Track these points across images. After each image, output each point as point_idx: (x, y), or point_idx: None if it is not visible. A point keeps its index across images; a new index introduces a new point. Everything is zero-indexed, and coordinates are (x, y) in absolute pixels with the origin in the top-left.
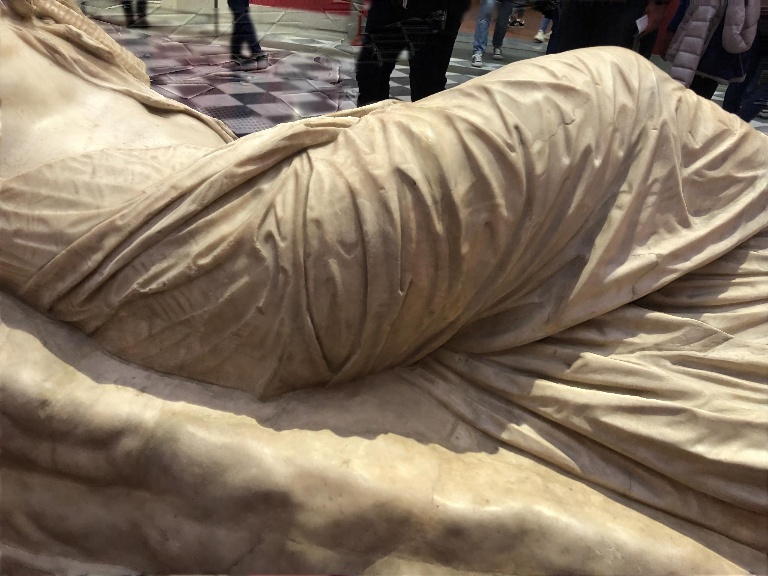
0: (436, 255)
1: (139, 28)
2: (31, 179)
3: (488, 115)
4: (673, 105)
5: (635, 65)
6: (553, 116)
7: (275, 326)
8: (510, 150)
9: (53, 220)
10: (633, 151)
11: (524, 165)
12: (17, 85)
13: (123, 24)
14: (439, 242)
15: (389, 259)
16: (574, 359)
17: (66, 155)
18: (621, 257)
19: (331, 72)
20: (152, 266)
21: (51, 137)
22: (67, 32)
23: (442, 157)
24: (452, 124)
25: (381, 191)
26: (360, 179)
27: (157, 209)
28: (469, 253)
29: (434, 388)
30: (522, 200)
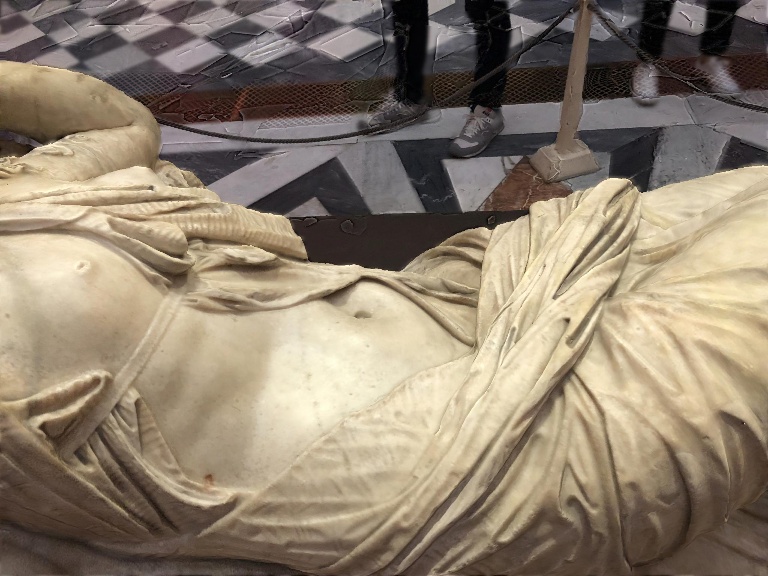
0: (762, 475)
1: (149, 20)
2: (284, 488)
3: None
4: None
5: None
6: None
7: (586, 571)
8: None
9: (326, 529)
10: None
11: None
12: (221, 374)
13: (130, 21)
14: None
15: (717, 500)
16: None
17: (307, 444)
18: None
19: (374, 8)
20: (447, 551)
21: (280, 423)
22: (229, 261)
23: None
24: None
25: (704, 440)
26: (674, 428)
27: (442, 501)
28: None
29: (722, 535)
30: None
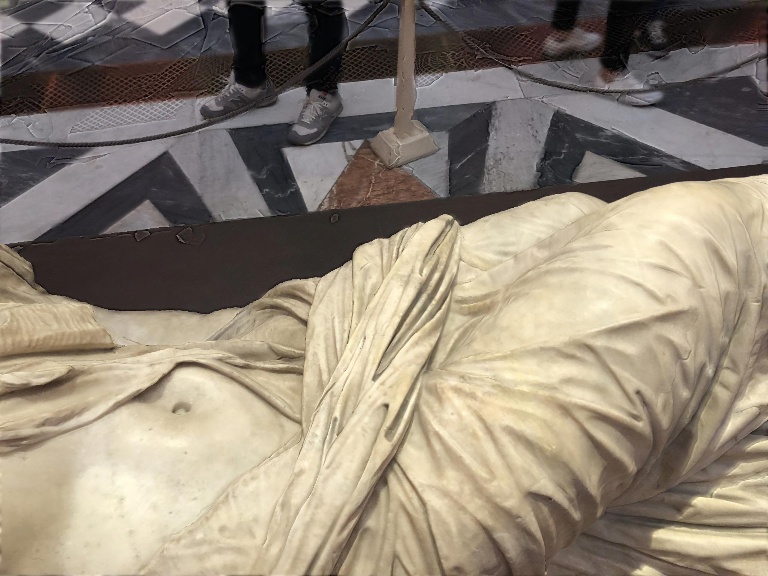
0: (574, 530)
1: None
2: None
3: (602, 384)
4: (766, 254)
5: (727, 228)
6: (669, 356)
7: None
8: (637, 420)
9: None
10: (735, 327)
11: (650, 423)
12: (13, 528)
13: None
14: (578, 525)
15: (535, 564)
16: (685, 507)
17: None
18: (725, 418)
19: None
20: None
21: (91, 563)
22: (9, 389)
23: (572, 463)
24: (570, 415)
25: (517, 520)
26: (490, 513)
27: None
28: (603, 512)
29: None
30: (649, 450)
